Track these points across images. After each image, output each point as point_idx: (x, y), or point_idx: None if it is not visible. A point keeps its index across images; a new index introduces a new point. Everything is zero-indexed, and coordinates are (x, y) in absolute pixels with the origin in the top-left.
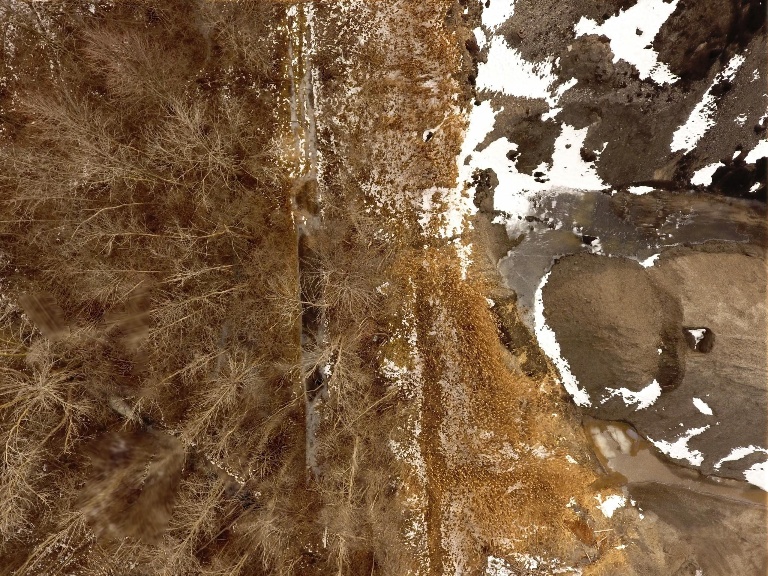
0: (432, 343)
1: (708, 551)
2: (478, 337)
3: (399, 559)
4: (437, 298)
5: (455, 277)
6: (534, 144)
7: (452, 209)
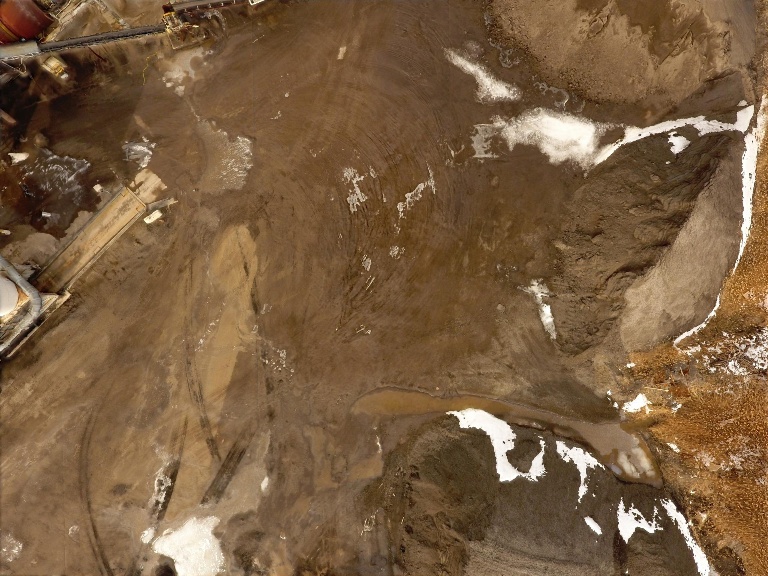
0: None
1: (545, 357)
2: (760, 564)
3: None
4: None
5: None
6: None
7: None
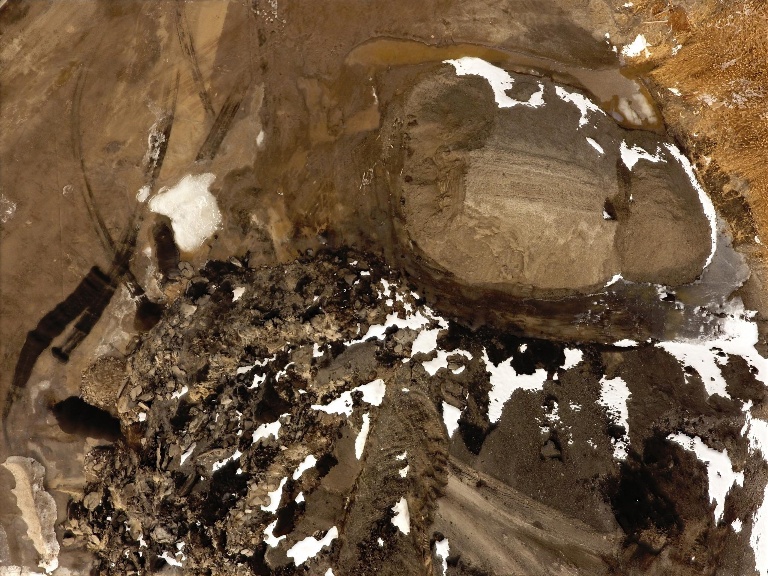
0: None
1: (541, 0)
2: (767, 208)
3: None
4: None
5: None
6: (746, 380)
7: None
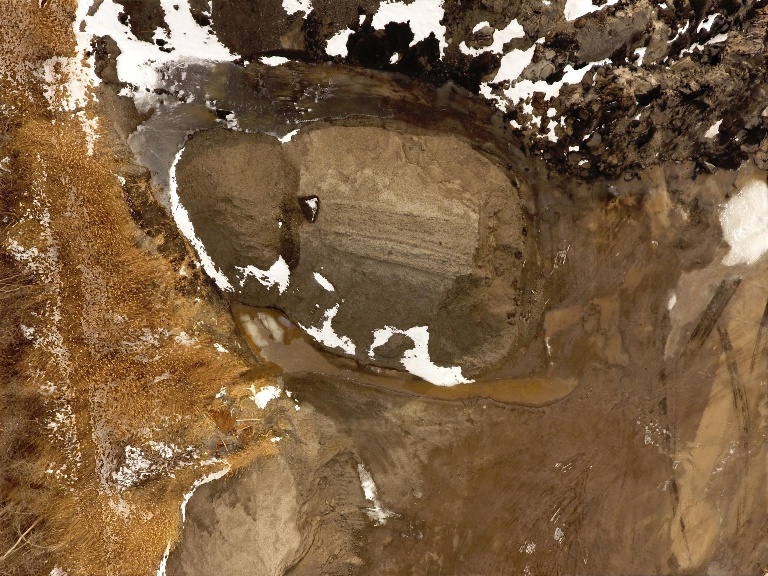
0: (67, 225)
1: (370, 444)
2: (111, 217)
3: (40, 451)
4: (66, 176)
5: (82, 153)
6: (137, 4)
7: (72, 79)
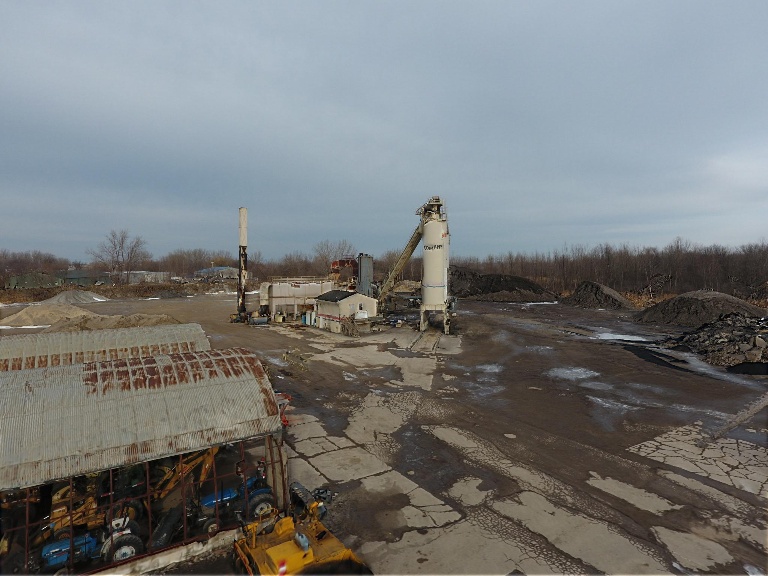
0: None
1: None
2: None
3: None
4: None
5: None
6: None
7: None
